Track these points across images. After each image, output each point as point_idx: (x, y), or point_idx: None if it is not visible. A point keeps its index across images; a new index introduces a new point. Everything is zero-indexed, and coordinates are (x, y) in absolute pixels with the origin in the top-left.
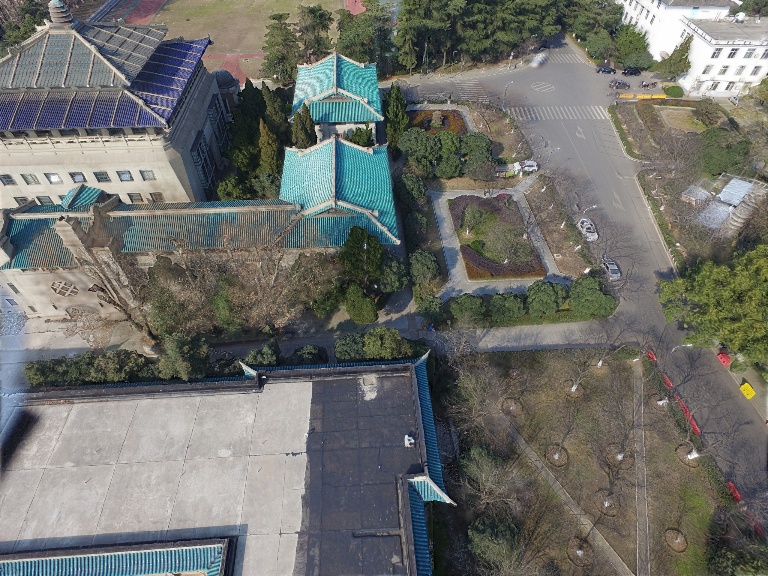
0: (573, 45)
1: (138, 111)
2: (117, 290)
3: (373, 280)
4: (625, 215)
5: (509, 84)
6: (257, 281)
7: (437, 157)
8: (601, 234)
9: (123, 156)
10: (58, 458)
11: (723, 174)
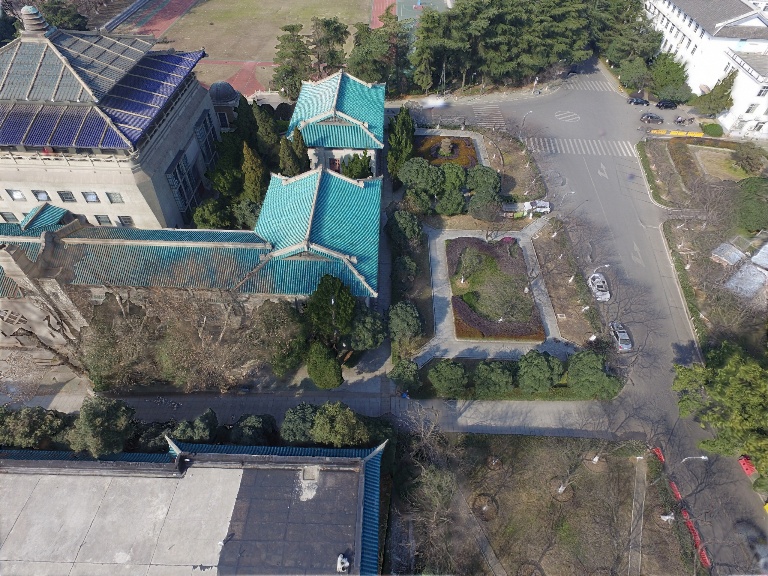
0: (605, 71)
1: (104, 130)
2: (69, 322)
3: (343, 336)
4: (644, 272)
5: None
6: None
7: (439, 191)
8: (614, 293)
9: (88, 176)
10: None
11: (762, 231)
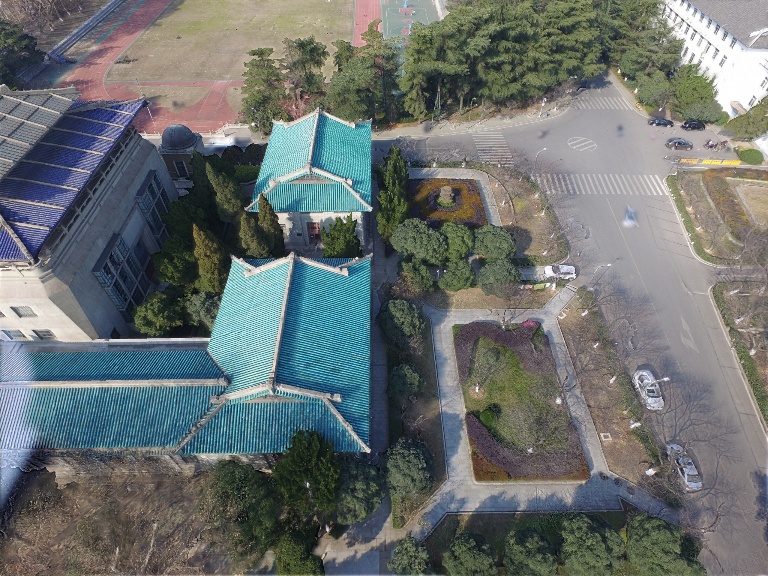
0: (618, 85)
1: None
2: None
3: None
4: (700, 361)
5: (541, 151)
6: (115, 570)
7: (442, 260)
8: (667, 396)
9: None
10: None
11: None
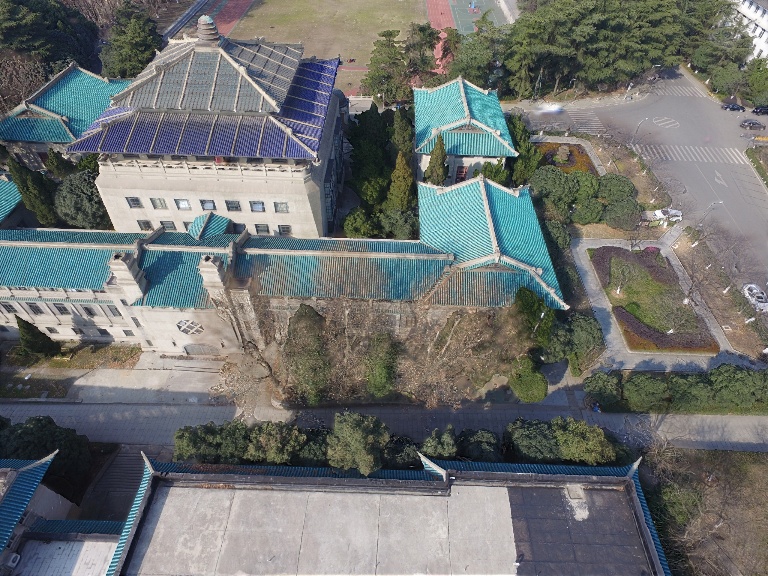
0: (690, 76)
1: (285, 140)
2: (243, 332)
3: (535, 348)
4: None
5: None
6: None
7: (572, 199)
8: None
9: (260, 186)
10: (227, 564)
11: None
